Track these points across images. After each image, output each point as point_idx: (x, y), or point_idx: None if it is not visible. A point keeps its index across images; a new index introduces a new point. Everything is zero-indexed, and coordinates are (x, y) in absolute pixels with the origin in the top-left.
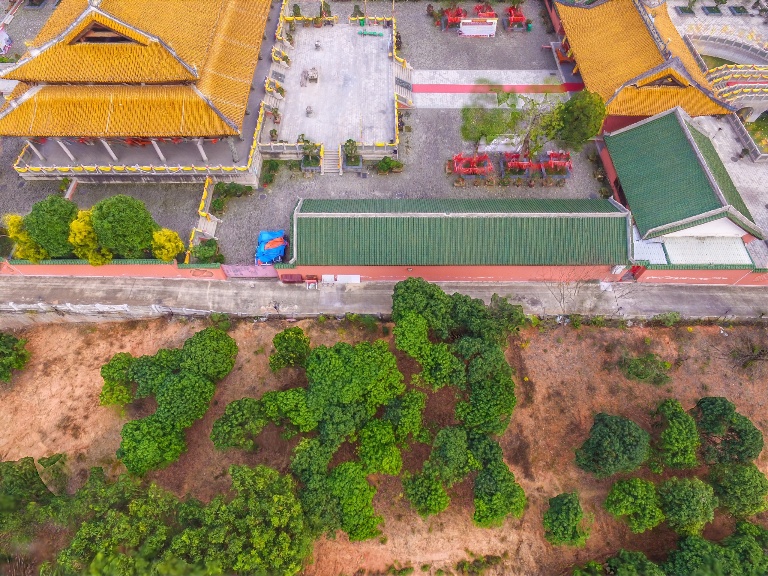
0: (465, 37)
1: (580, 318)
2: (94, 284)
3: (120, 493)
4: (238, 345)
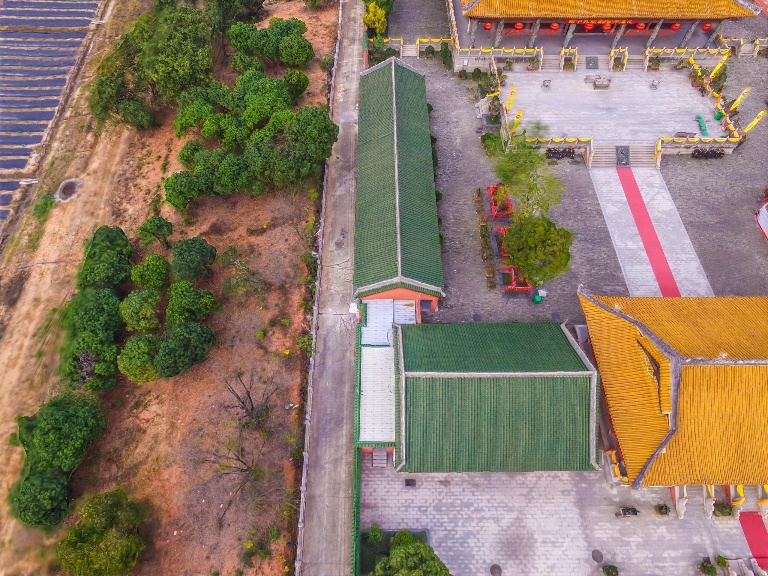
0: (756, 222)
1: (307, 258)
2: (360, 12)
3: (210, 19)
4: (311, 74)
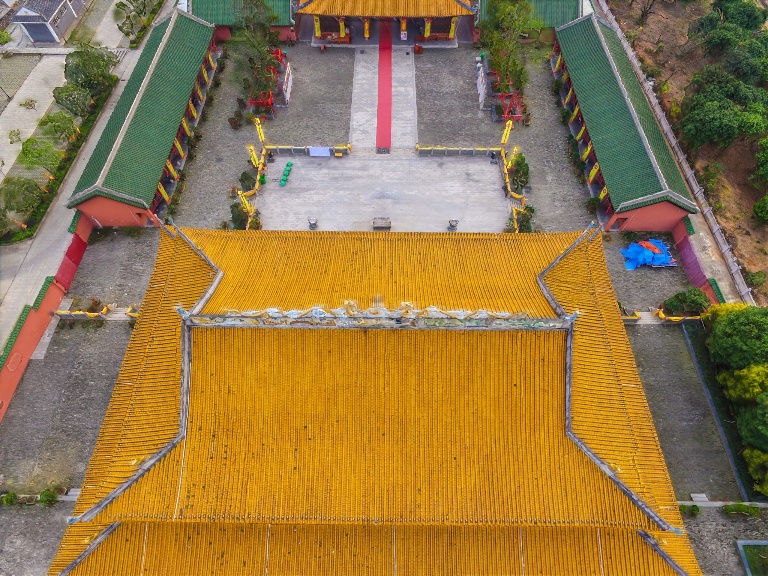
0: (290, 102)
1: (656, 67)
2: None
3: None
4: (765, 269)
